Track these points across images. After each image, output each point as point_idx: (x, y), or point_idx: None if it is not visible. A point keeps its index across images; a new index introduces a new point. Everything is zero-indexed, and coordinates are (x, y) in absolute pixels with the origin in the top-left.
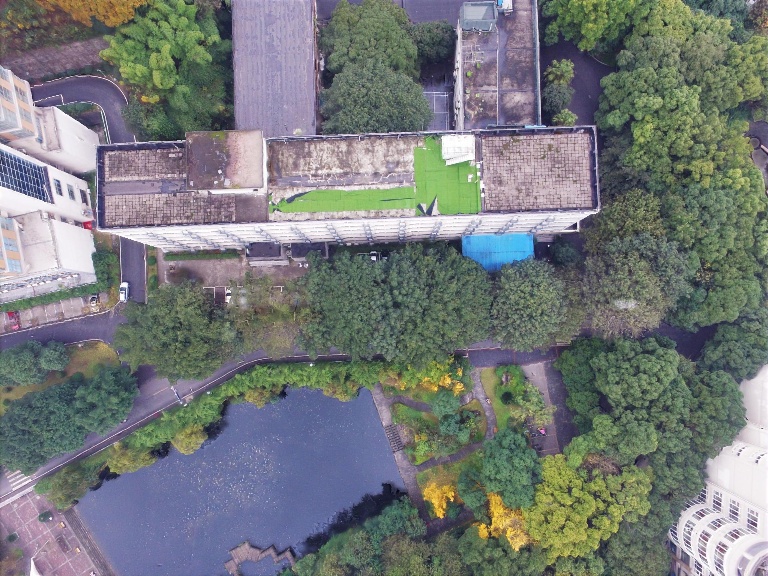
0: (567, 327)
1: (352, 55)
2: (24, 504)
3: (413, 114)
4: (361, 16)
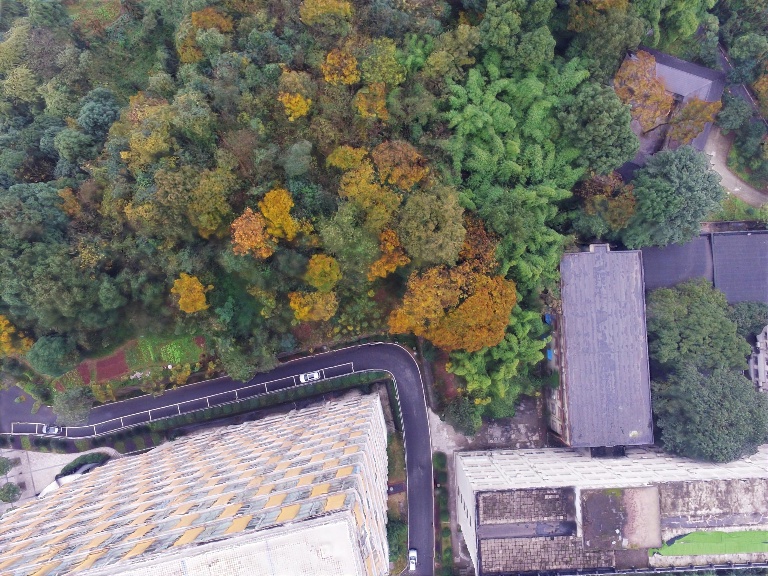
0: None
1: (684, 352)
2: None
3: None
4: (691, 310)
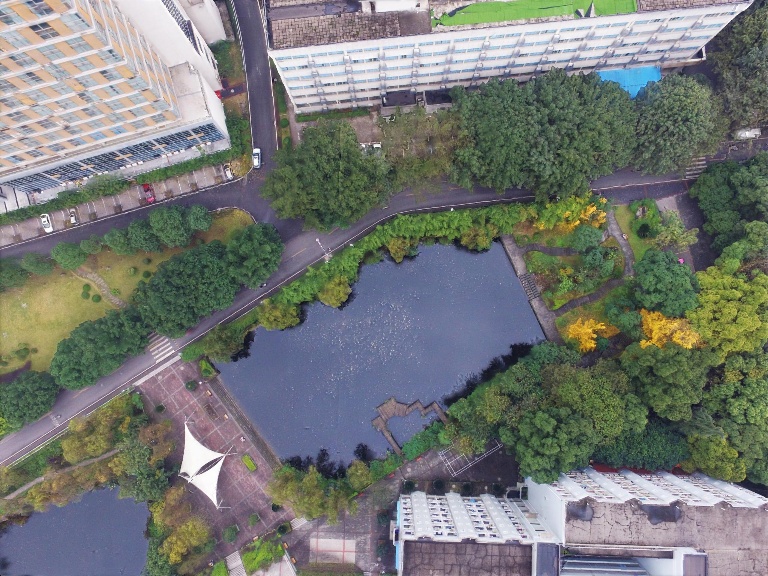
0: (713, 138)
1: None
2: (168, 376)
3: None
4: None
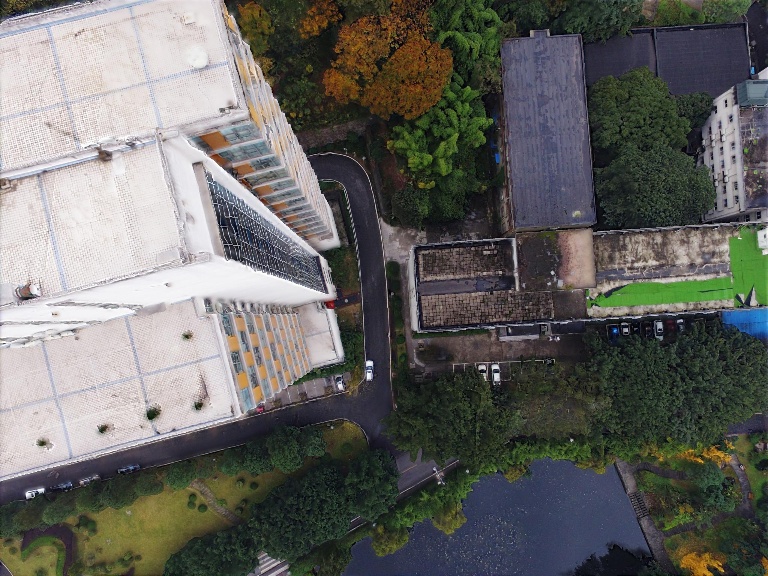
0: None
1: (626, 134)
2: None
3: (705, 197)
4: (632, 93)
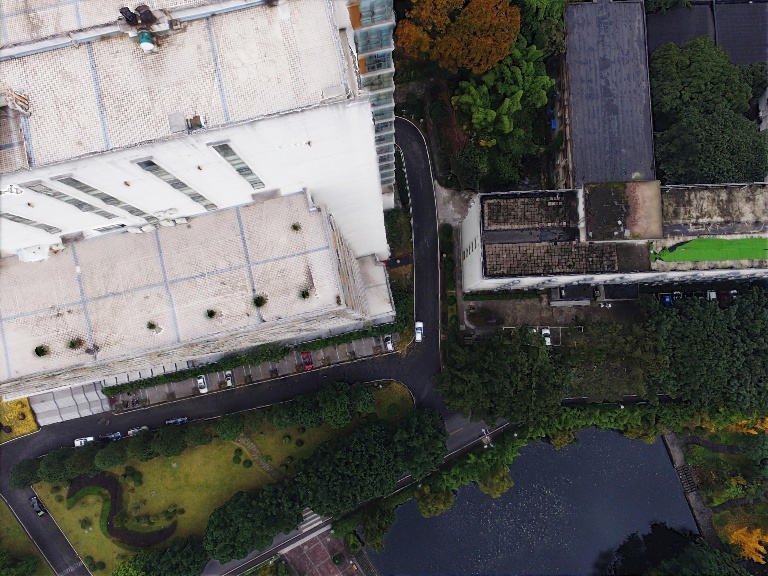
0: None
1: (687, 99)
2: (314, 546)
3: (767, 160)
4: (693, 59)
